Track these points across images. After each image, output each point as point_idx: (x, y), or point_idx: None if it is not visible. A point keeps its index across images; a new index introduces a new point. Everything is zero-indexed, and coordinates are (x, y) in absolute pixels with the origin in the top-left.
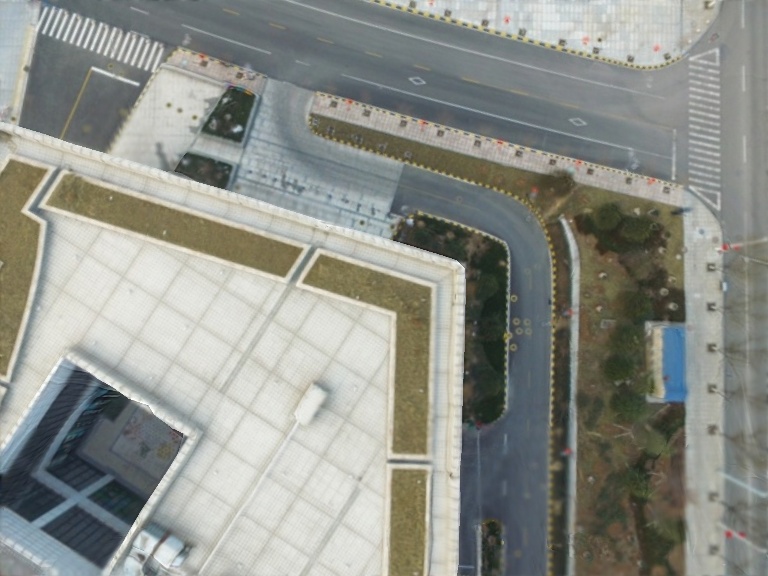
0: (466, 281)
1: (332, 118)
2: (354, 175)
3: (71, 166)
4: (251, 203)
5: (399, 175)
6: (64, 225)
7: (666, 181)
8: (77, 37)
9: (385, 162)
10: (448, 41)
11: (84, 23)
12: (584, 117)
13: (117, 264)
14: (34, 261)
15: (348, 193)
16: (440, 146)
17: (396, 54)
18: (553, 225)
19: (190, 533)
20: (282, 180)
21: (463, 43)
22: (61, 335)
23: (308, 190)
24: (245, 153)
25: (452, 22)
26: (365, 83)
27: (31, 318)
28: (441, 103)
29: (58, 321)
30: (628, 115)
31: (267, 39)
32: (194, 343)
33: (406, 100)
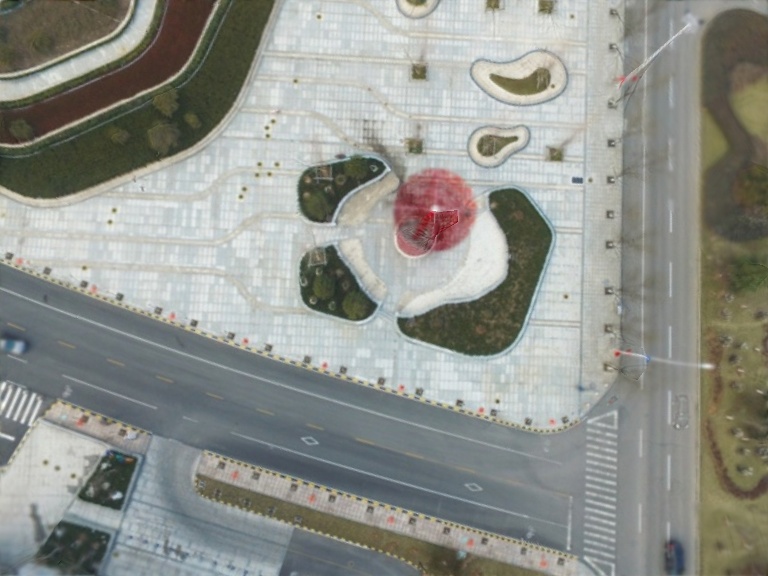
0: None
1: (219, 481)
2: (241, 540)
3: None
4: None
5: (289, 539)
6: None
7: (561, 551)
8: None
9: (274, 526)
10: (343, 399)
11: None
12: (480, 482)
13: None
14: None
15: (234, 559)
16: (331, 513)
17: (288, 412)
18: None
19: None
20: (164, 546)
21: (358, 401)
22: None
23: (192, 556)
24: (126, 517)
25: (347, 379)
26: (255, 442)
27: None
28: (334, 465)
29: None
30: (525, 481)
31: (153, 393)
32: None
33: (298, 461)
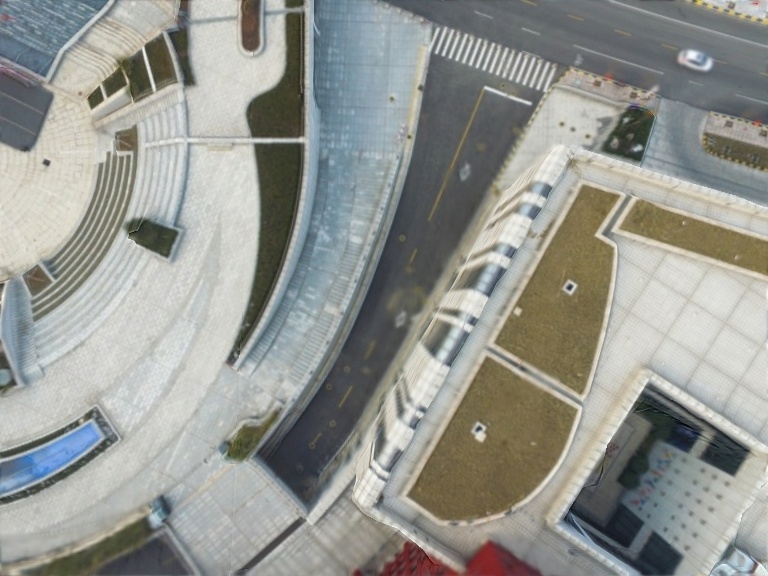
0: None
1: (728, 138)
2: (749, 194)
3: (633, 191)
4: None
5: None
6: (629, 249)
7: None
8: (470, 57)
9: None
10: None
11: (476, 43)
12: None
13: (683, 287)
14: (609, 284)
15: None
16: None
17: None
18: None
19: (761, 551)
20: None
21: None
22: (629, 356)
23: None
24: None
25: None
26: (760, 103)
27: (605, 339)
28: None
29: (626, 342)
30: None
31: (659, 59)
32: (758, 365)
33: None
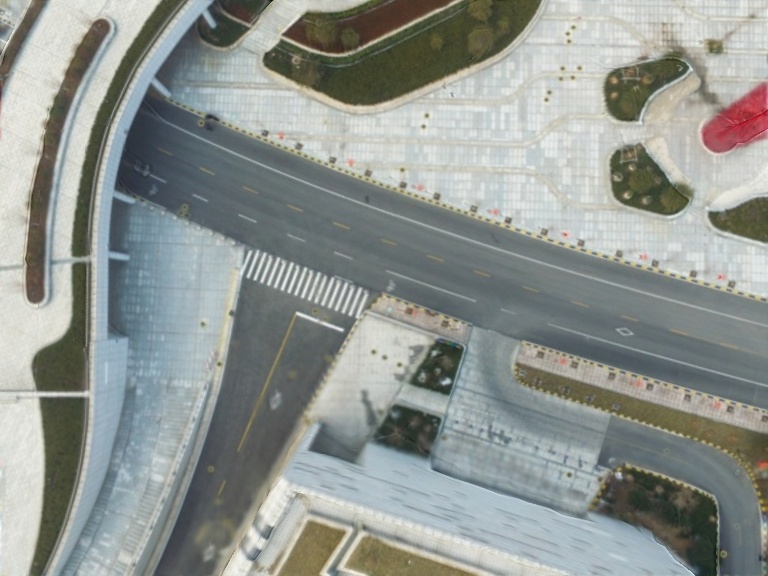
0: (676, 538)
1: (539, 369)
2: (561, 426)
3: (363, 521)
4: (550, 569)
5: (606, 426)
6: None
7: None
8: (281, 282)
9: (592, 413)
10: (655, 291)
11: (288, 267)
12: None
13: None
14: None
15: (555, 444)
16: (649, 400)
17: (603, 304)
18: (764, 481)
19: None
20: (488, 431)
21: (671, 293)
22: None
23: (514, 441)
24: (451, 403)
25: (659, 272)
26: (571, 333)
27: None
28: (649, 355)
29: None
30: None
31: (472, 286)
32: None
33: (613, 351)
